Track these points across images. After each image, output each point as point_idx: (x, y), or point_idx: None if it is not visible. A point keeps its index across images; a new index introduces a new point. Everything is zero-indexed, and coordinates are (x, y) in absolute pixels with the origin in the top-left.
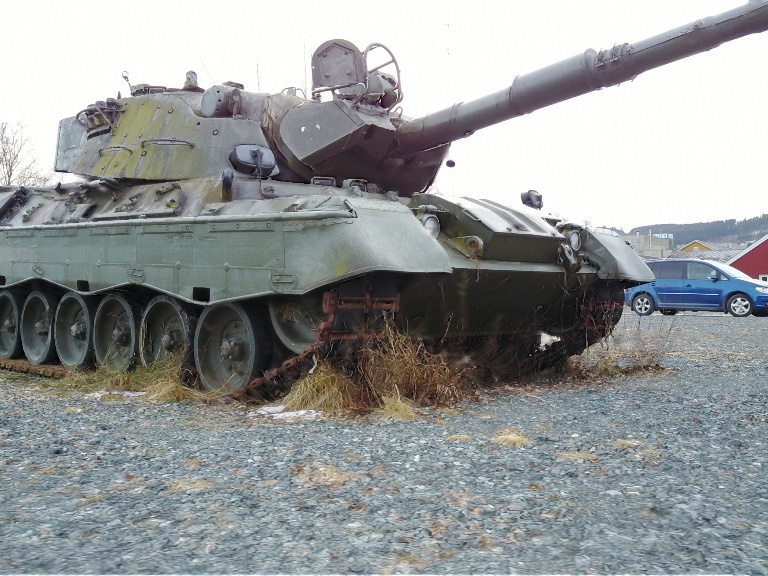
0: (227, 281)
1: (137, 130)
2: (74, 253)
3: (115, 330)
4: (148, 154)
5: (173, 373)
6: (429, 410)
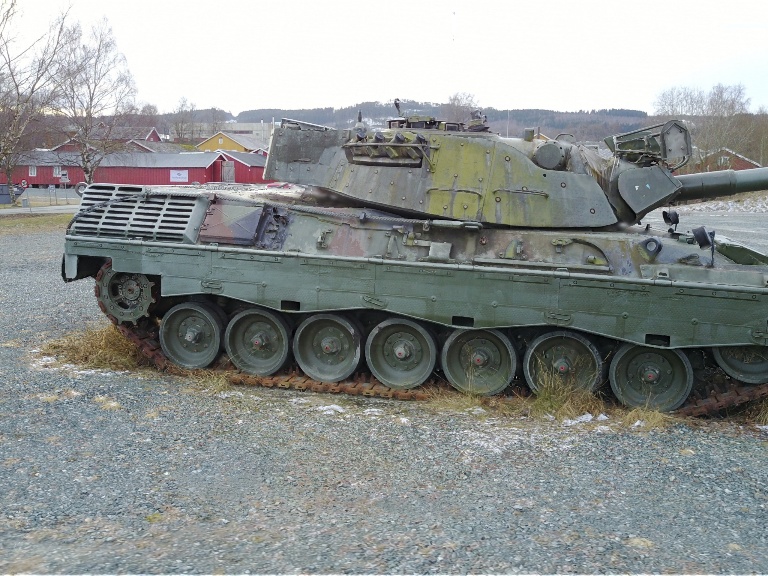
0: (695, 332)
1: (472, 173)
2: (447, 291)
3: (479, 356)
4: (503, 201)
5: (592, 396)
6: None
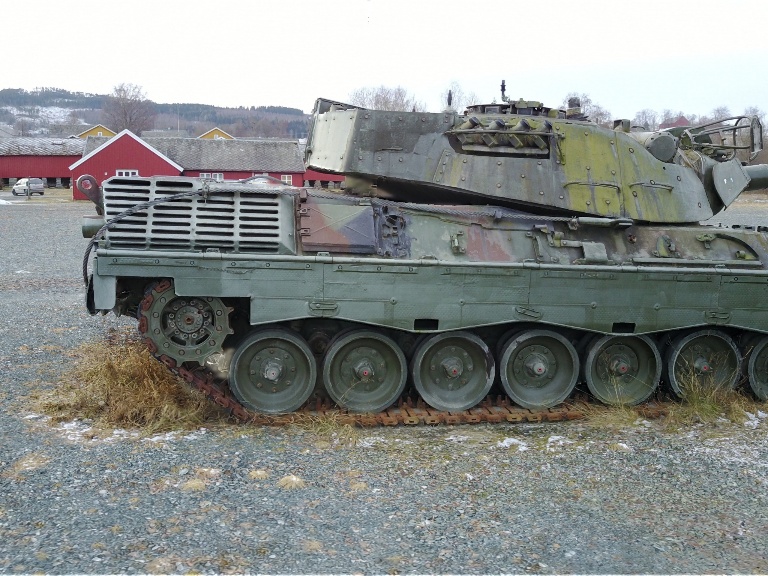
0: None
1: (604, 165)
2: (609, 296)
3: (623, 364)
4: (639, 195)
5: None
6: None
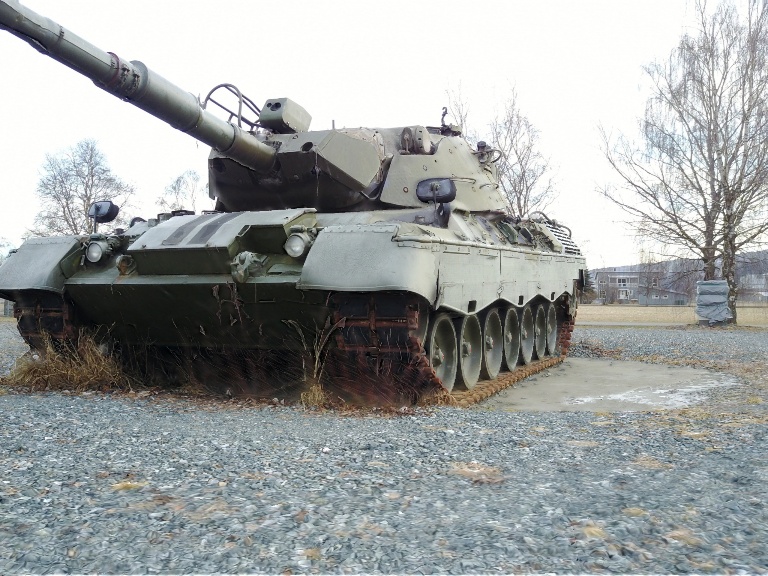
0: None
1: None
2: None
3: None
4: None
5: None
6: (11, 390)
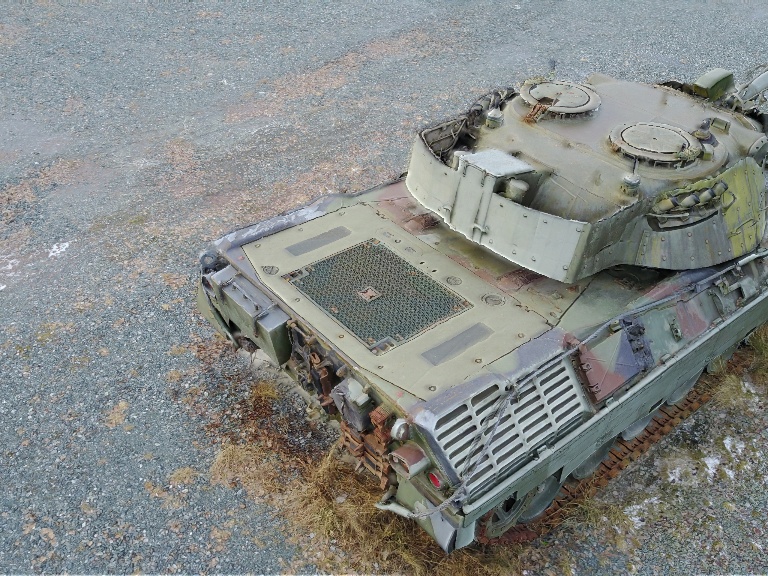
0: None
1: None
2: None
3: None
4: None
5: None
6: None
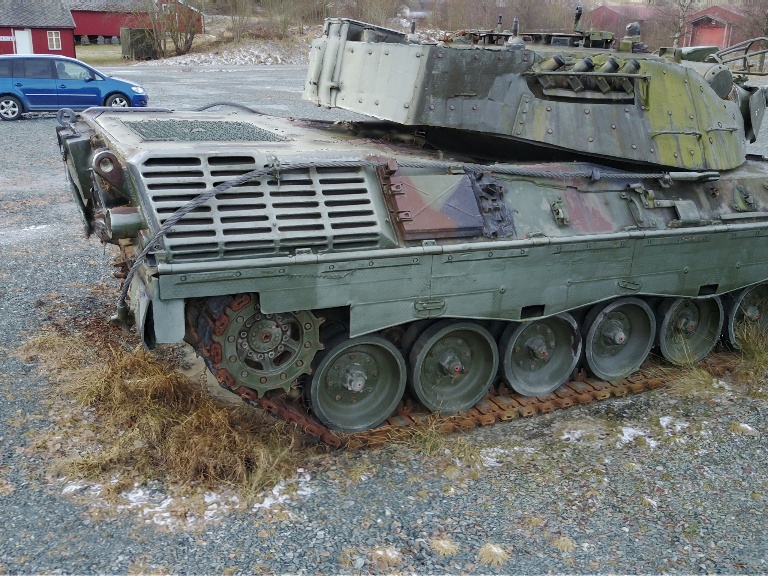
0: None
1: (683, 109)
2: (701, 259)
3: (692, 322)
4: None
5: None
6: None
